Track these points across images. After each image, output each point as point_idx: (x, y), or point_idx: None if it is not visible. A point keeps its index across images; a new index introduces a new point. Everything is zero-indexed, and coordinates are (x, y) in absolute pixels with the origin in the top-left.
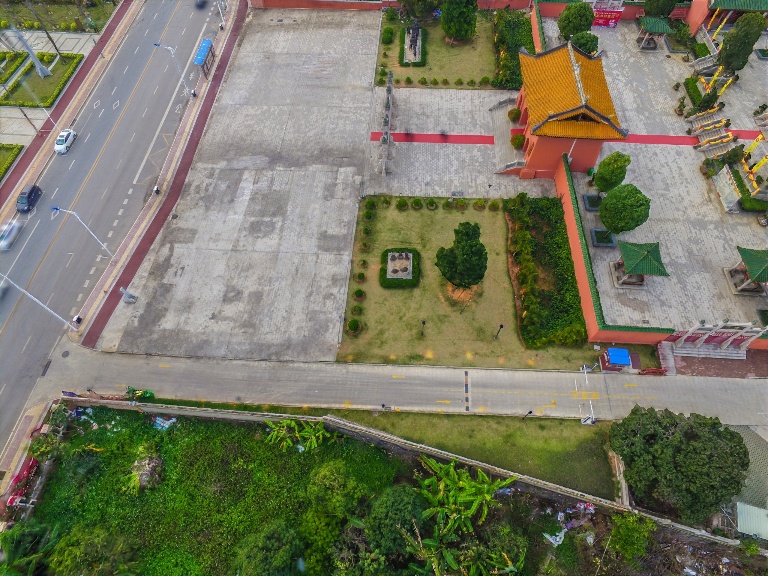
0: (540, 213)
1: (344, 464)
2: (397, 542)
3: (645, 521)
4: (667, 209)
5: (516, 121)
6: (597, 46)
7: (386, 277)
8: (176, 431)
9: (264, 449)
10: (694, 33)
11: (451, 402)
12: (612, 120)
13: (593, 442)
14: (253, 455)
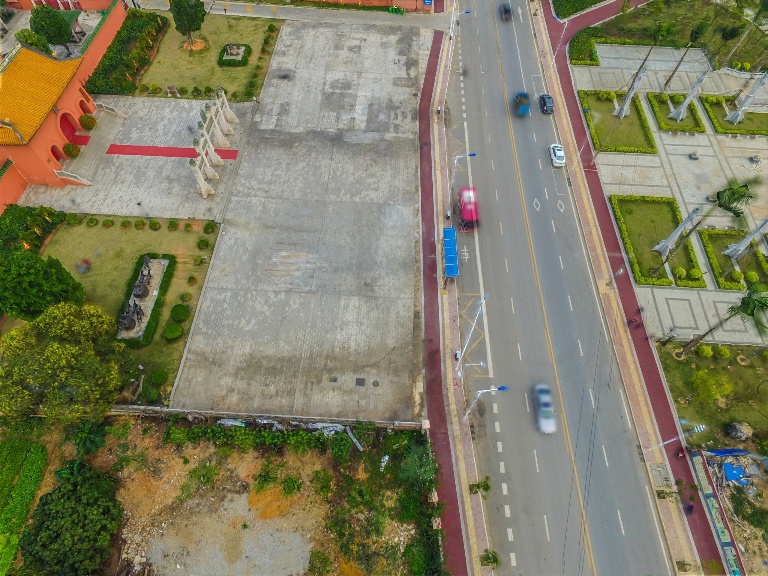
0: None
1: None
2: None
3: None
4: None
5: None
6: None
7: (246, 47)
8: None
9: None
10: None
11: (222, 4)
12: None
13: None
14: None
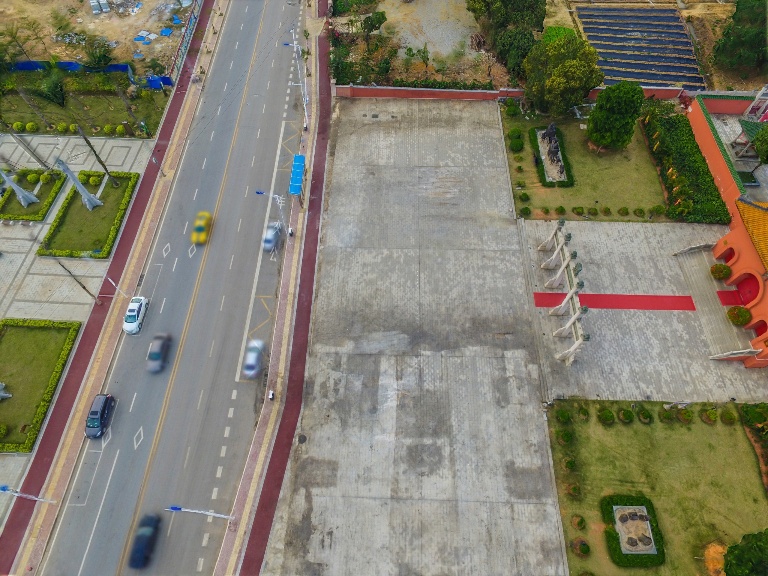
0: None
1: None
2: None
3: None
4: None
5: (722, 279)
6: None
7: (622, 552)
8: None
9: None
10: None
11: None
12: None
13: None
14: None
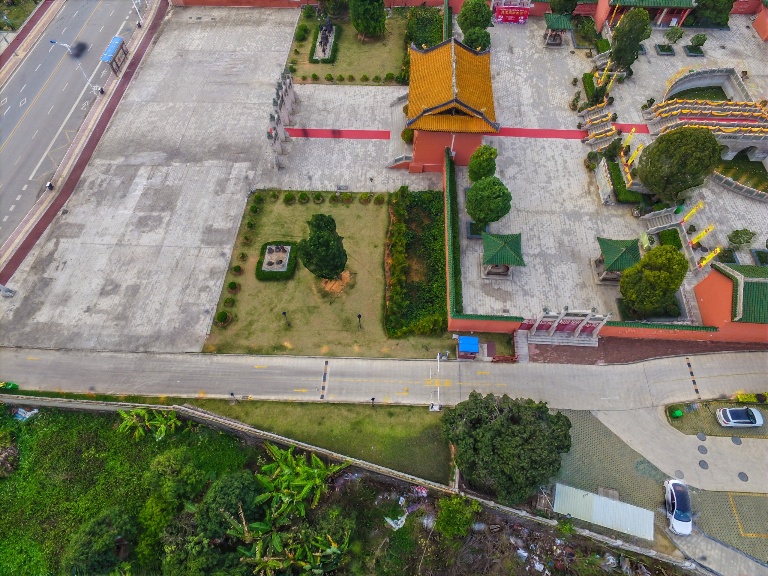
0: (422, 206)
1: (183, 451)
2: (224, 526)
3: (471, 503)
4: (546, 201)
5: None
6: (489, 42)
7: (261, 269)
8: (36, 422)
9: (121, 438)
10: (600, 29)
11: (307, 391)
12: (487, 114)
13: (437, 428)
14: (108, 444)
